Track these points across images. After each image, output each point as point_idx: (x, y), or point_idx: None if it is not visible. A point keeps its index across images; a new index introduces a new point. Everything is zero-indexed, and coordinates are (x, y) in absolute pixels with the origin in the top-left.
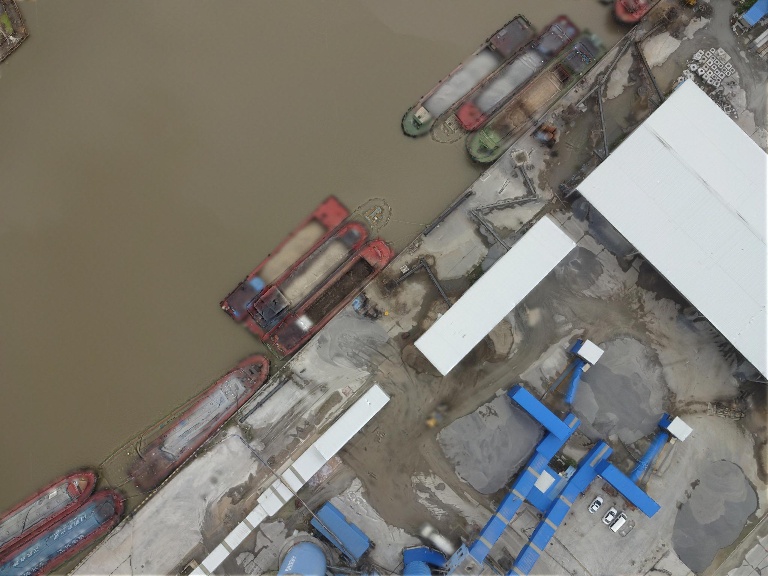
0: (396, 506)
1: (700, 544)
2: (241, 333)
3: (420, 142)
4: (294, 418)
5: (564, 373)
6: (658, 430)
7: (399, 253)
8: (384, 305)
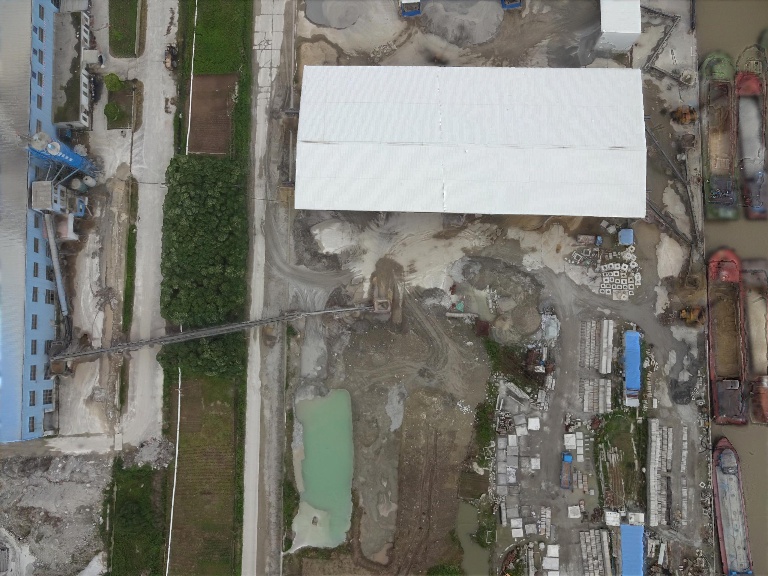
0: None
1: None
2: None
3: (761, 37)
4: None
5: None
6: None
7: None
8: None
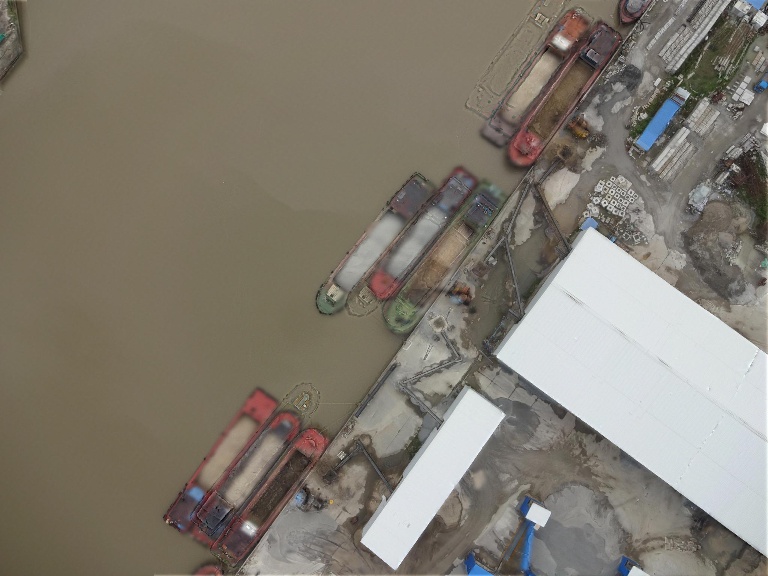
0: None
1: None
2: (189, 544)
3: (337, 318)
4: None
5: (516, 538)
6: (619, 574)
7: (334, 436)
8: (328, 493)
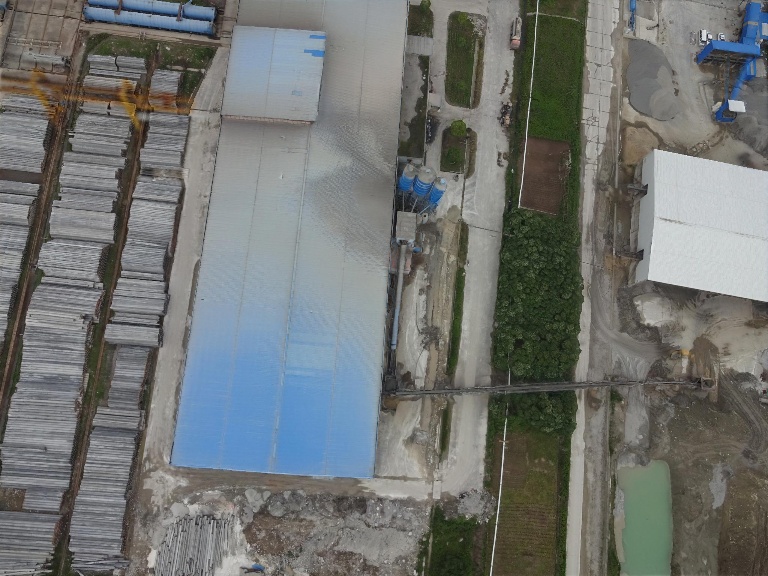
0: None
1: (655, 53)
2: None
3: None
4: None
5: None
6: None
7: None
8: None
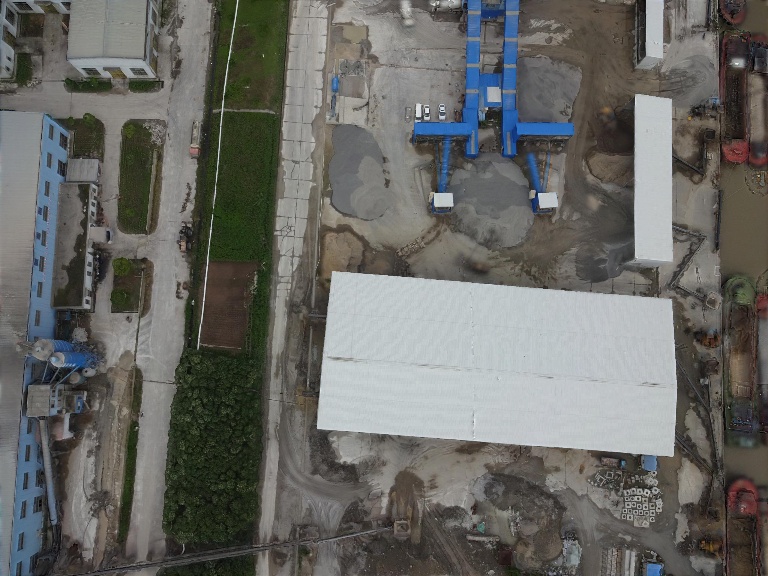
0: (565, 5)
1: (356, 142)
2: (761, 30)
3: None
4: (679, 4)
5: None
6: None
7: None
8: (696, 123)
